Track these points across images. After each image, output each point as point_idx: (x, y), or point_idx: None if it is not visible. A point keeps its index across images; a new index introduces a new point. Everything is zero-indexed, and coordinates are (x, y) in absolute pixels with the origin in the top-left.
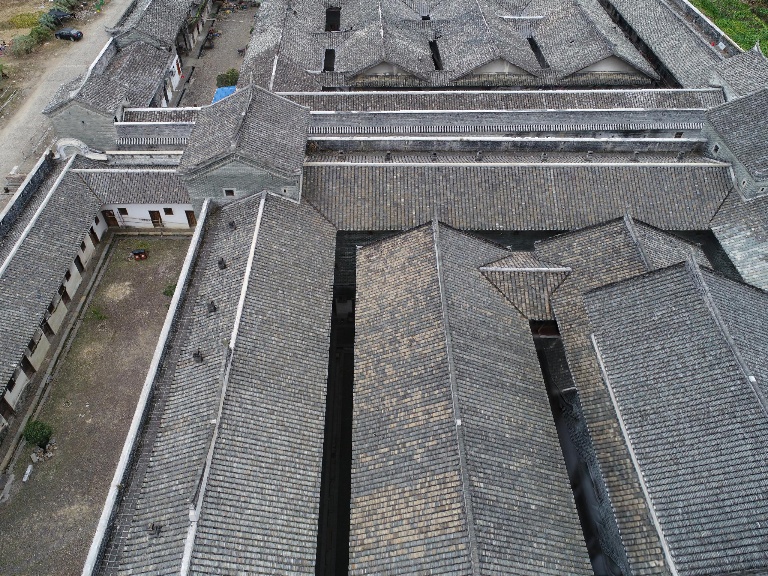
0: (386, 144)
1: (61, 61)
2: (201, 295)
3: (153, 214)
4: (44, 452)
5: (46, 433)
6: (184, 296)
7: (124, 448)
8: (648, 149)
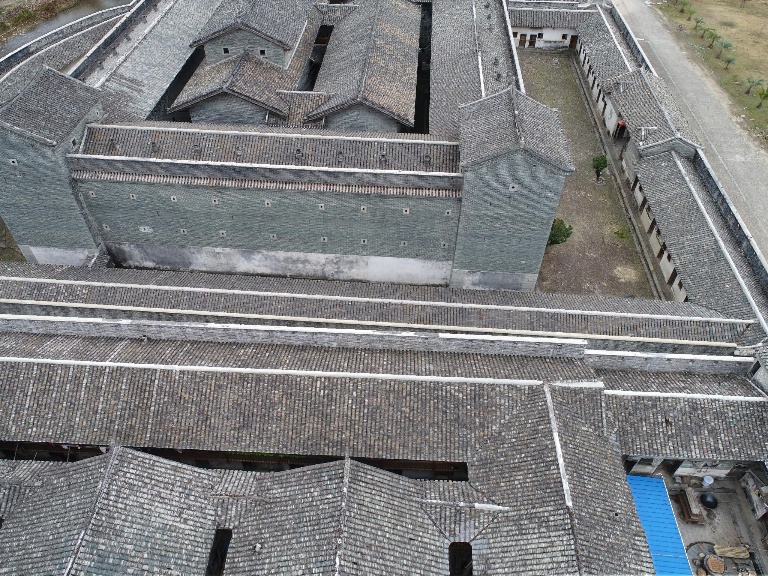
0: None
1: None
2: None
3: None
4: (598, 178)
5: None
6: None
7: None
8: None
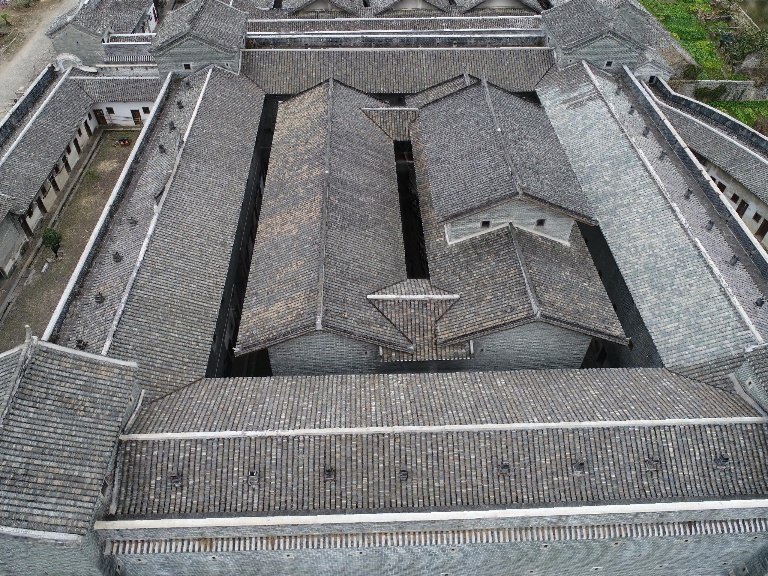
0: (306, 41)
1: (55, 13)
2: (166, 124)
3: (134, 113)
4: (56, 256)
5: (58, 236)
6: (154, 125)
7: (114, 190)
8: (502, 44)
